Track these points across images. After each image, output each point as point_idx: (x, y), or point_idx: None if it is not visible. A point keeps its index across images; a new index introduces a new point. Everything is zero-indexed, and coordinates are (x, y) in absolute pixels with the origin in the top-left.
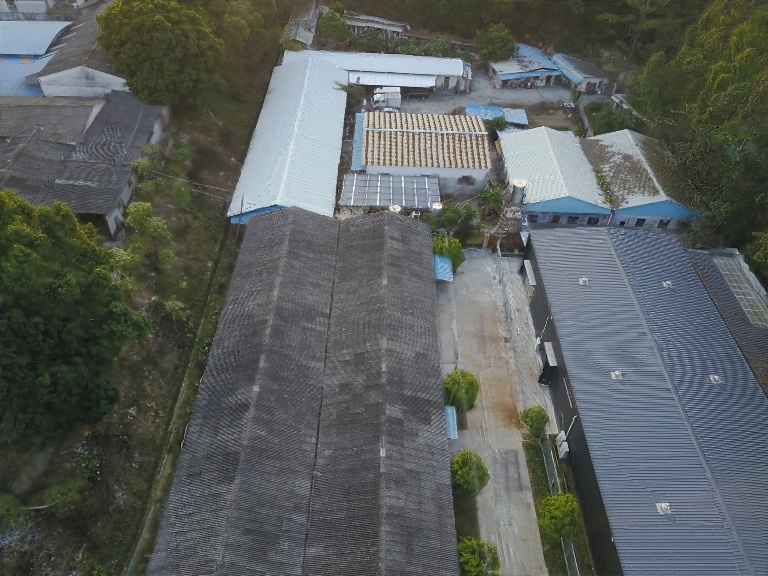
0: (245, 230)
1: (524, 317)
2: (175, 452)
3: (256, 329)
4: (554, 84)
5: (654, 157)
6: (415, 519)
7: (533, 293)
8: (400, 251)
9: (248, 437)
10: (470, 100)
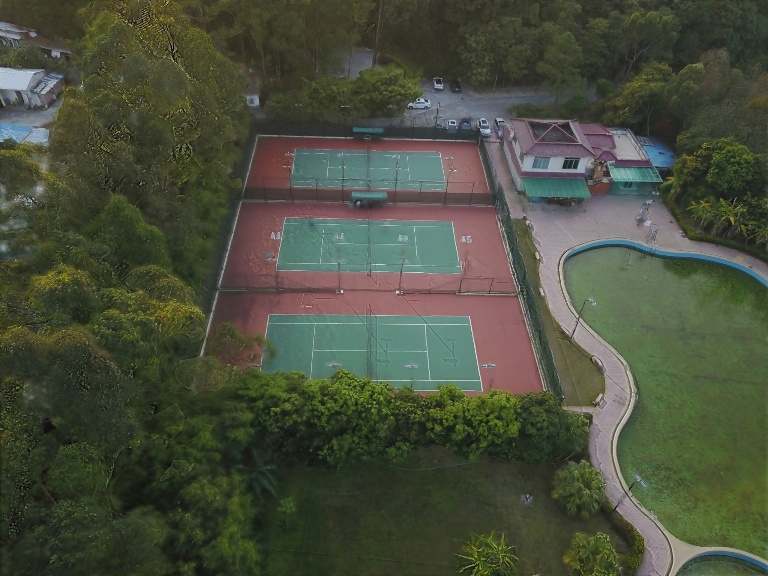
0: None
1: None
2: None
3: None
4: None
5: None
6: None
7: None
8: None
9: None
10: (37, 117)
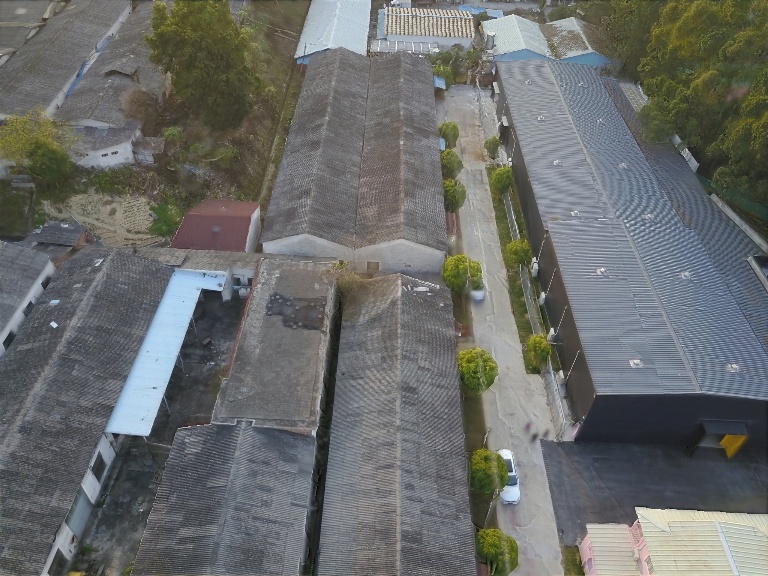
0: (306, 68)
1: (492, 117)
2: (276, 162)
3: (323, 98)
4: (527, 0)
5: (590, 32)
6: (420, 167)
7: (498, 99)
8: (411, 69)
9: (325, 135)
10: None
